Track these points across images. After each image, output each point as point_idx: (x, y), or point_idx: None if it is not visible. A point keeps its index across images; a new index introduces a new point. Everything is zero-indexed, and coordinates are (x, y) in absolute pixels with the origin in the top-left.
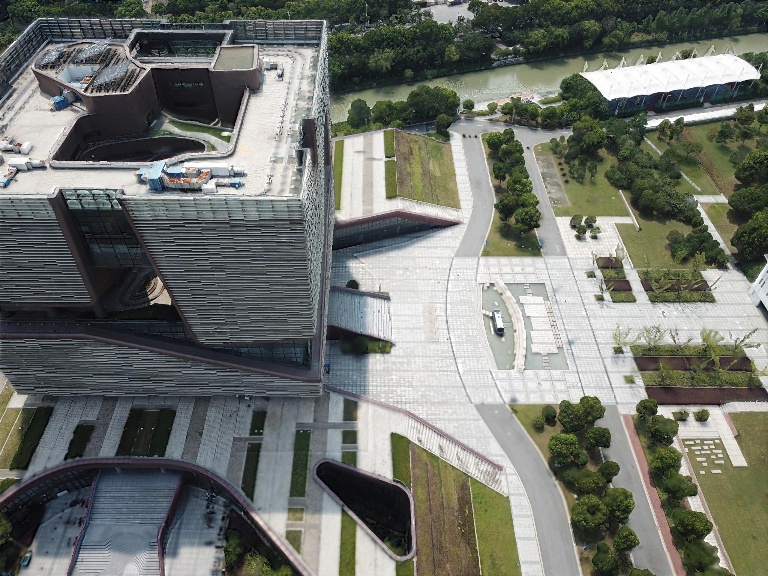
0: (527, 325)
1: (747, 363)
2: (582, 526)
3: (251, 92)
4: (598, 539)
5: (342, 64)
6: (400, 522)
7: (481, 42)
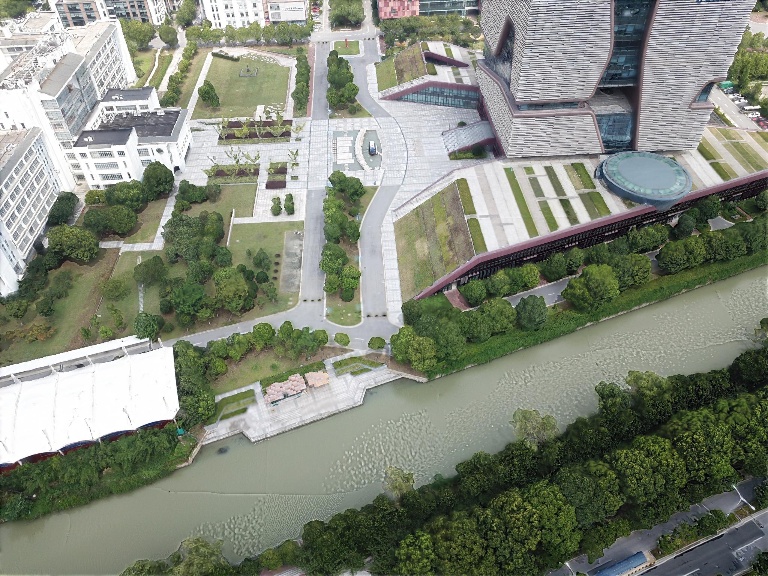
0: (353, 149)
1: None
2: None
3: None
4: None
5: (605, 411)
6: None
7: (335, 521)
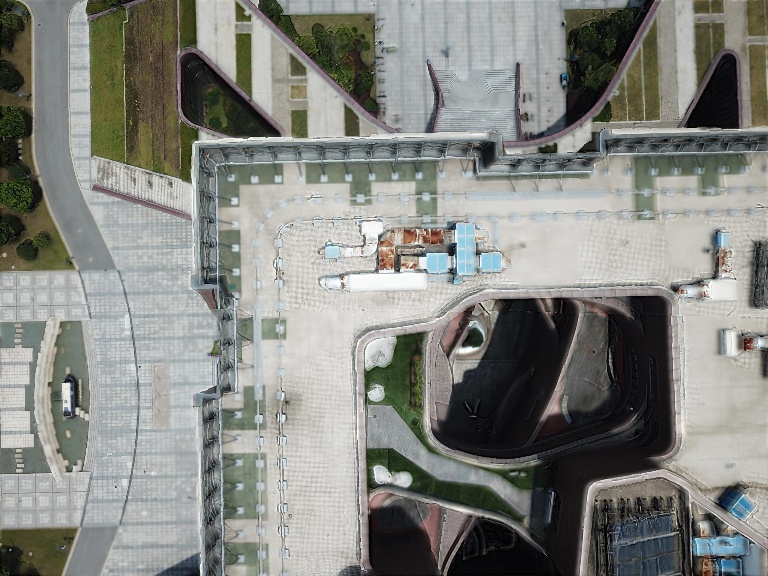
0: (32, 395)
1: None
2: (15, 109)
3: (359, 572)
4: None
5: None
6: None
7: None
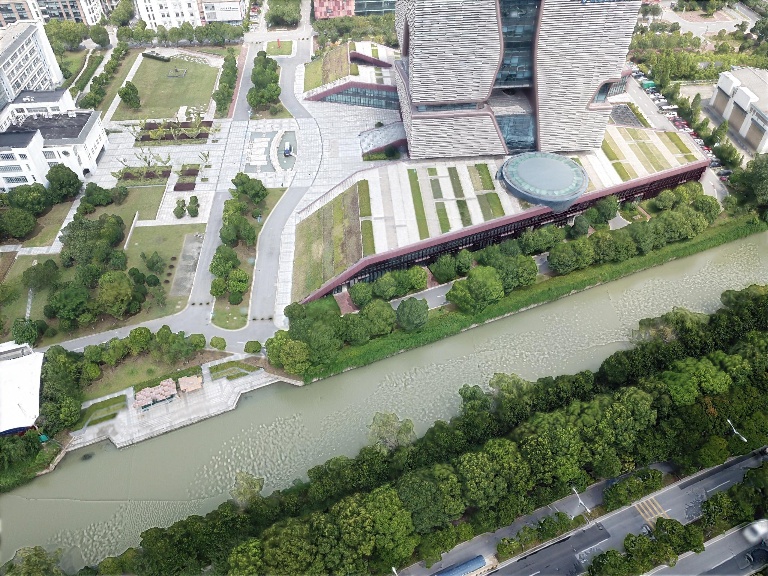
0: (268, 151)
1: None
2: None
3: None
4: None
5: (463, 414)
6: None
7: (174, 528)
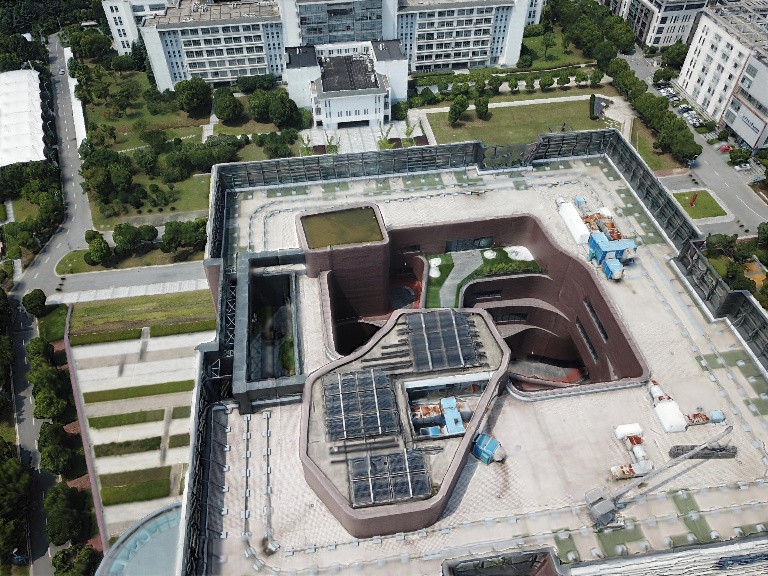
0: None
1: (395, 139)
2: None
3: None
4: None
5: None
6: None
7: None
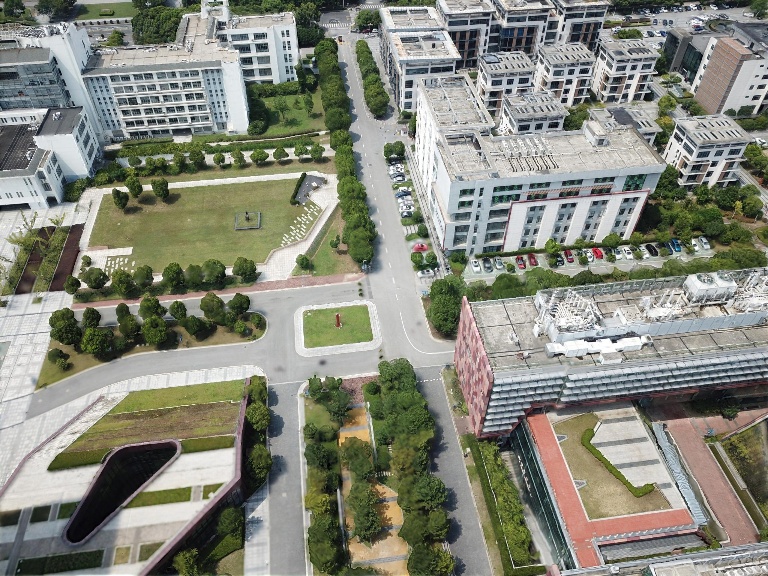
0: None
1: (47, 229)
2: (165, 336)
3: None
4: (174, 335)
5: None
6: (136, 489)
7: None
